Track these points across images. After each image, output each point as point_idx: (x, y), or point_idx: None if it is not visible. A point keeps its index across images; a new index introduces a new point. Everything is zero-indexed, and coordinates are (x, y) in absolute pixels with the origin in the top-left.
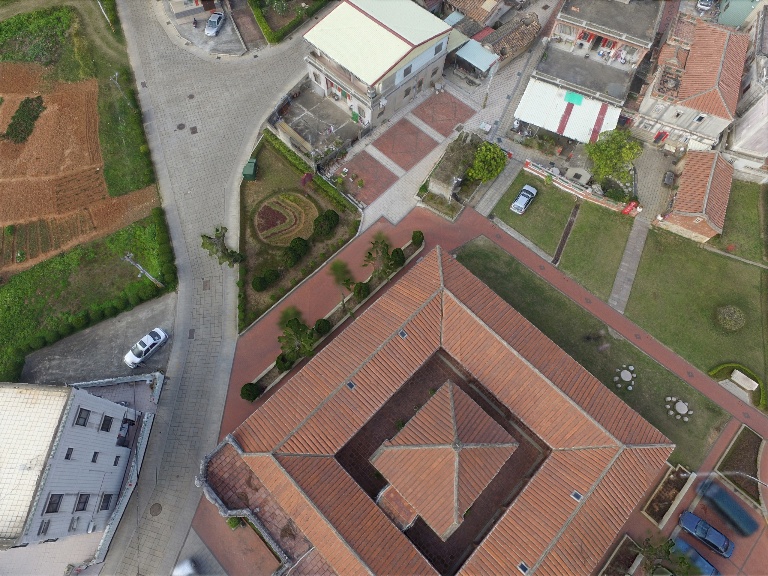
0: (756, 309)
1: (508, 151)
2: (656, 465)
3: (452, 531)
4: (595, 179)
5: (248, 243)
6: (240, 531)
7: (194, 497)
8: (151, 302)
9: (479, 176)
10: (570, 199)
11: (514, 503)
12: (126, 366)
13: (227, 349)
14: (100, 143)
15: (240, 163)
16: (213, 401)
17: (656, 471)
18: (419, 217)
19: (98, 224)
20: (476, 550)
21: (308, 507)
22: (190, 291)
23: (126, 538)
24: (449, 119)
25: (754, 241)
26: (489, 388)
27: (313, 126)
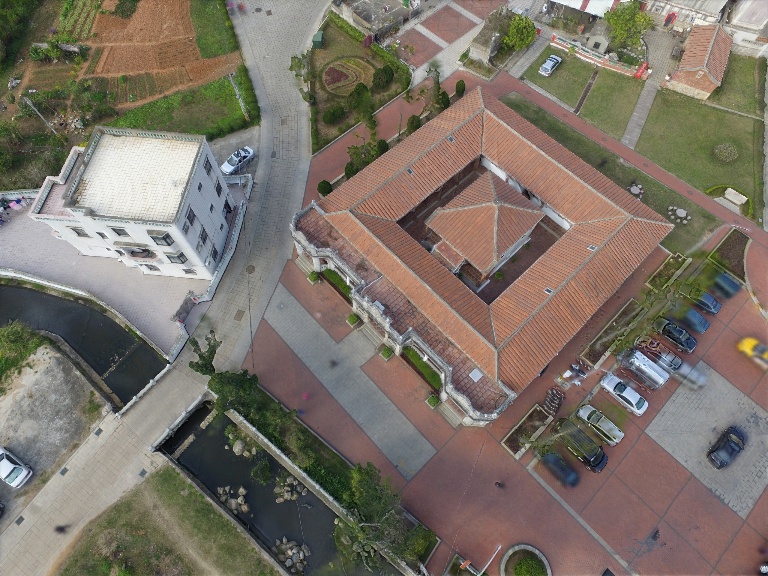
0: (749, 149)
1: (537, 27)
2: (658, 237)
3: (492, 267)
4: (612, 48)
5: (317, 93)
6: (318, 286)
7: (280, 262)
8: (239, 132)
9: (513, 42)
10: (590, 67)
11: (541, 257)
12: (222, 174)
13: (303, 166)
14: (192, 20)
15: (309, 37)
16: (293, 200)
17: (658, 241)
18: (460, 77)
19: (193, 77)
20: (510, 285)
21: (378, 246)
22: (271, 125)
23: (228, 287)
24: (486, 7)
25: (749, 99)
26: (521, 182)
27: (370, 10)
